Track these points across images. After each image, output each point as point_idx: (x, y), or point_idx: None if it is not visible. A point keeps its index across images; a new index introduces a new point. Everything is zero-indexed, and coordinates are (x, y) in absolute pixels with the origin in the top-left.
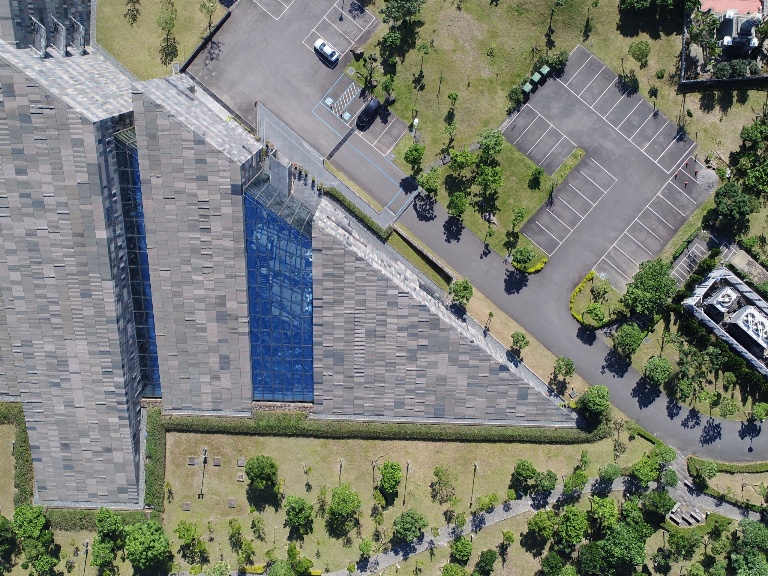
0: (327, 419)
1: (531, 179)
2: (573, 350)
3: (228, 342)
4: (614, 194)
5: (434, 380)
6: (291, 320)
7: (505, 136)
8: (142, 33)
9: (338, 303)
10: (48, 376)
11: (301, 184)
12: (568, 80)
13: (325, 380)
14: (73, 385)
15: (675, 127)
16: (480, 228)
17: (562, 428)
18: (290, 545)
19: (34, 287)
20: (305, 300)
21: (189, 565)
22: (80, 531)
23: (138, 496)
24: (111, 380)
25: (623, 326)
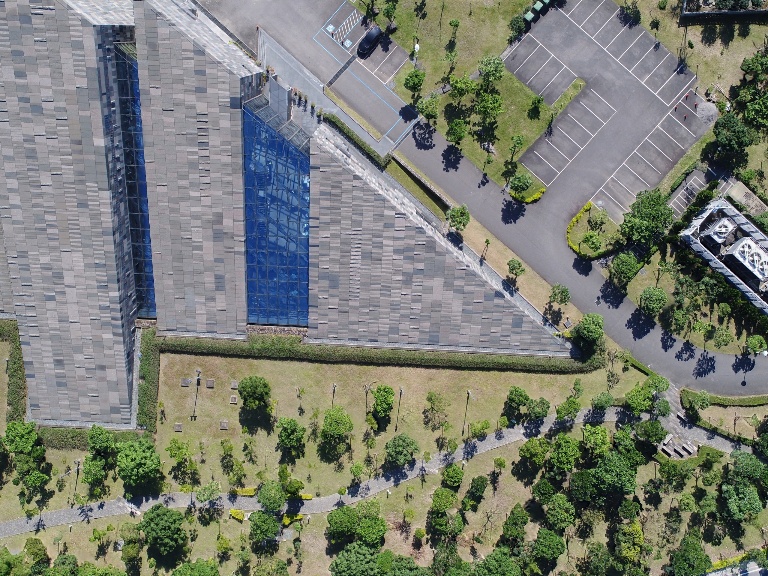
0: (321, 343)
1: (531, 109)
2: (569, 280)
3: (224, 261)
4: (613, 125)
5: (429, 305)
6: (287, 241)
7: (506, 65)
8: None
9: (335, 223)
10: (43, 289)
11: (301, 110)
12: (570, 10)
13: (320, 303)
14: (68, 299)
15: (676, 60)
16: (479, 157)
17: (556, 358)
18: (281, 467)
19: (31, 196)
20: (302, 226)
21: (180, 486)
22: (72, 450)
23: (131, 416)
24: (106, 294)
25: (619, 255)
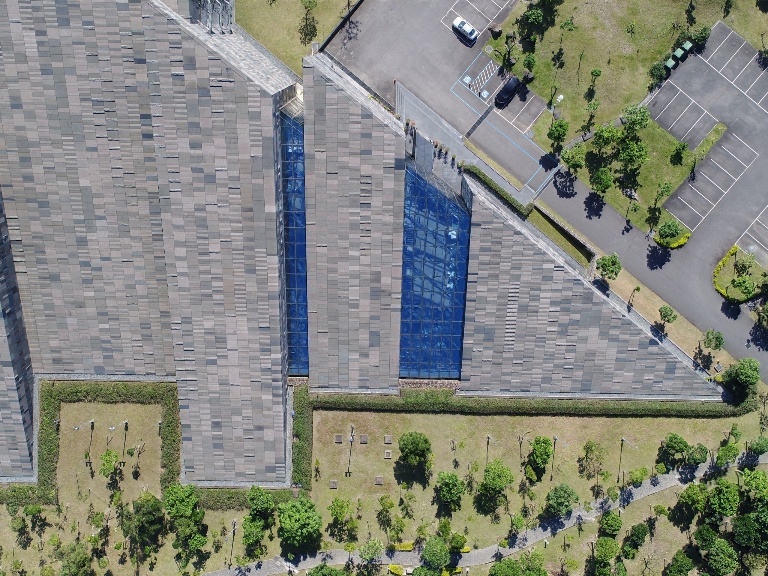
0: (474, 395)
1: (673, 155)
2: (718, 324)
3: (380, 318)
4: (756, 169)
5: (583, 355)
6: (443, 296)
7: None
8: (281, 13)
9: (493, 278)
10: (205, 353)
11: (441, 162)
12: (709, 56)
13: (474, 356)
14: (229, 362)
15: None
16: (621, 204)
17: (708, 402)
18: (442, 521)
19: (198, 263)
20: (446, 278)
21: (337, 543)
22: (227, 510)
23: (285, 475)
24: (268, 357)
25: None
